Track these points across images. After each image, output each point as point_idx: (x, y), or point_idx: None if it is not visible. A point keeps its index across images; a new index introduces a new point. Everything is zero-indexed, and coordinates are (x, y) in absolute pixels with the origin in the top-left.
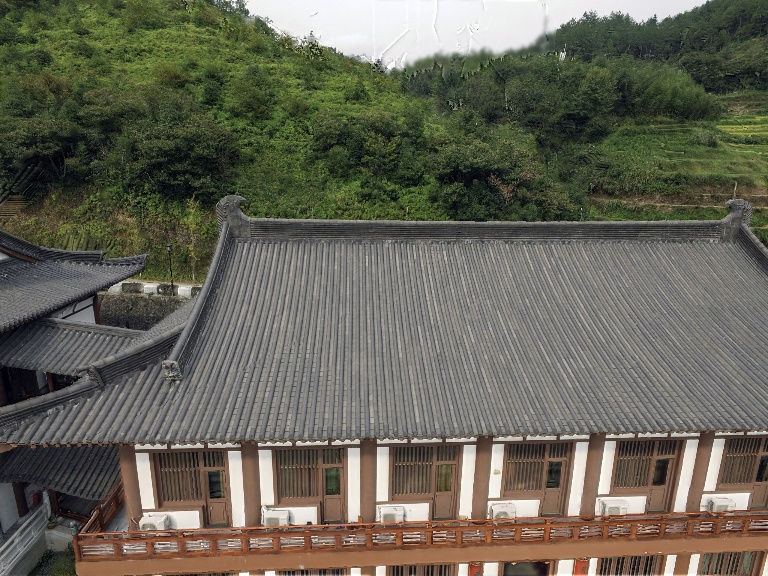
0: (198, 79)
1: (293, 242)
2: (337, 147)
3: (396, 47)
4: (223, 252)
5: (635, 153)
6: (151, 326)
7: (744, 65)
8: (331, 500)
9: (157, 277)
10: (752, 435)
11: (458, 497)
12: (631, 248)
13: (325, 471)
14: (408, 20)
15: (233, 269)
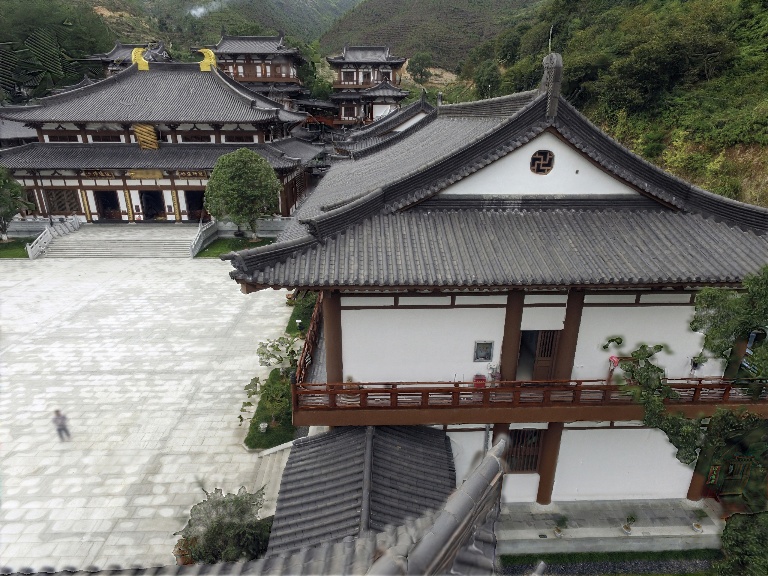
0: None
1: None
2: None
3: None
4: (421, 122)
5: None
6: None
7: None
8: None
9: None
10: None
11: None
12: None
13: None
14: None
15: None
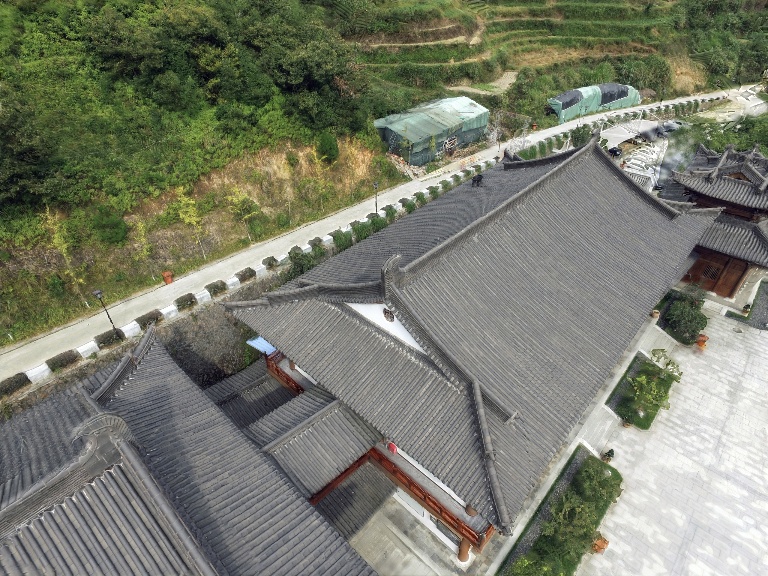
0: None
1: (429, 270)
2: (173, 74)
3: None
4: None
5: (415, 24)
6: None
7: None
8: None
9: (36, 328)
10: None
11: None
12: (566, 179)
13: None
14: None
15: None
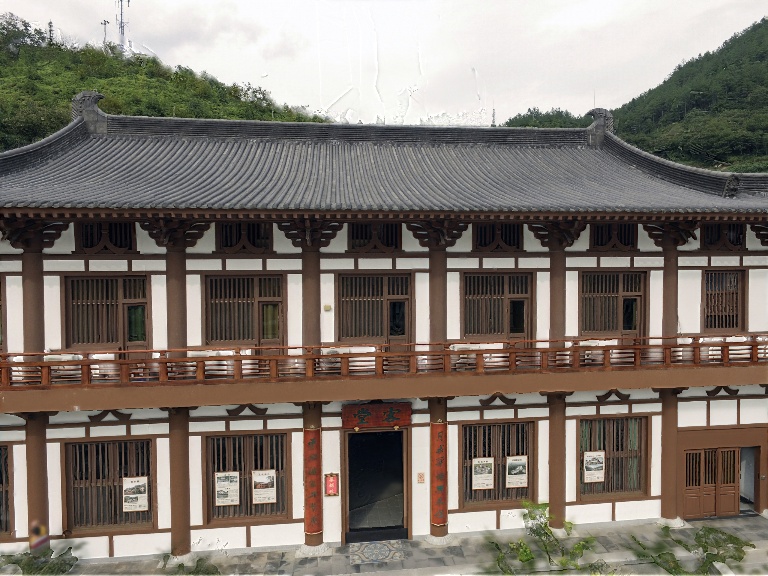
0: (139, 111)
1: (152, 139)
2: None
3: (340, 103)
4: (68, 134)
5: None
6: None
7: (668, 142)
8: (135, 349)
9: None
10: (606, 267)
11: (285, 341)
12: (500, 150)
13: (127, 310)
14: (352, 82)
15: (77, 151)
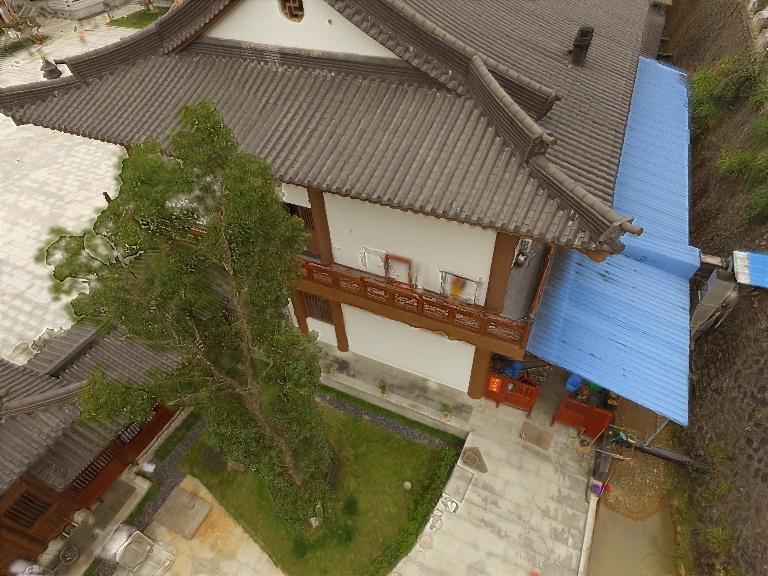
0: None
1: None
2: None
3: None
4: None
5: None
6: (707, 4)
7: None
8: None
9: None
10: None
11: None
12: None
13: None
14: None
15: None
